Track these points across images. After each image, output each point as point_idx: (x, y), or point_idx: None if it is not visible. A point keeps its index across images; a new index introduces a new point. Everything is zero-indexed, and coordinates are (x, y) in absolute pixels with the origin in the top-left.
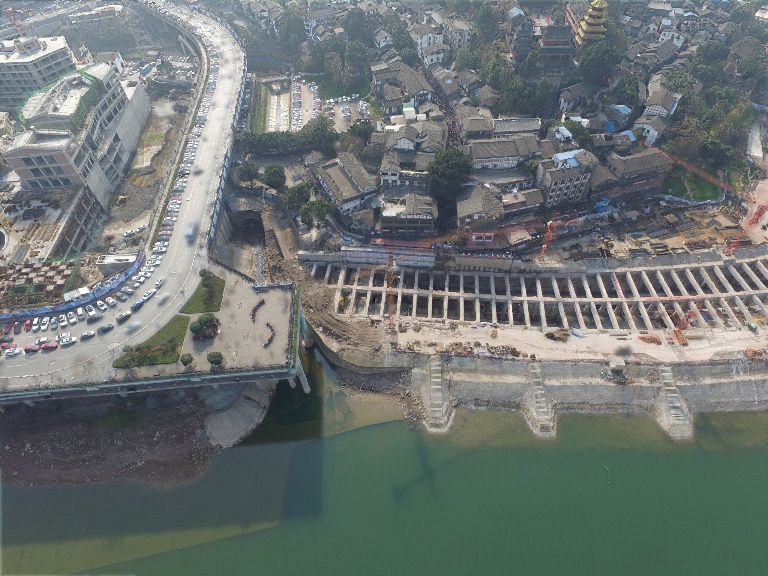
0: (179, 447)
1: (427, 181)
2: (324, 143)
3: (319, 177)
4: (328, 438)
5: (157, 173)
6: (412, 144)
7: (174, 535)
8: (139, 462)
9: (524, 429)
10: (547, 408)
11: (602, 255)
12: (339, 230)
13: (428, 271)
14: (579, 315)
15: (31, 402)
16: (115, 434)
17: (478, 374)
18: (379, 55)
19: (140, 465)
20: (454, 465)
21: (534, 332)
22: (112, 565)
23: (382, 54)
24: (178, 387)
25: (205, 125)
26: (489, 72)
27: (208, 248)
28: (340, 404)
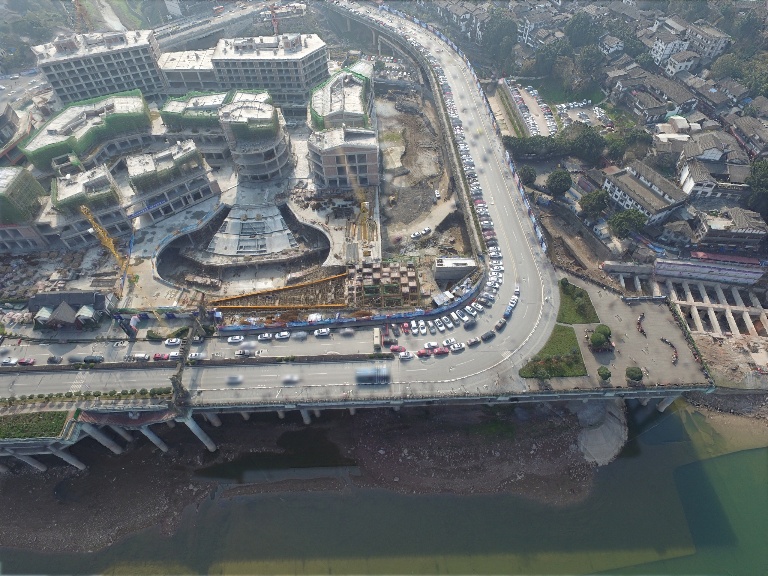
0: (556, 462)
1: (744, 194)
2: (596, 150)
3: (604, 185)
4: (706, 461)
5: (412, 174)
6: (720, 155)
7: (590, 556)
8: (519, 475)
9: None
10: None
11: None
12: (646, 241)
13: (747, 288)
14: None
15: None
16: (493, 445)
17: None
18: (609, 61)
19: (521, 478)
20: None
21: None
22: None
23: (612, 60)
24: None
25: (463, 127)
26: (763, 82)
27: None
28: (701, 425)
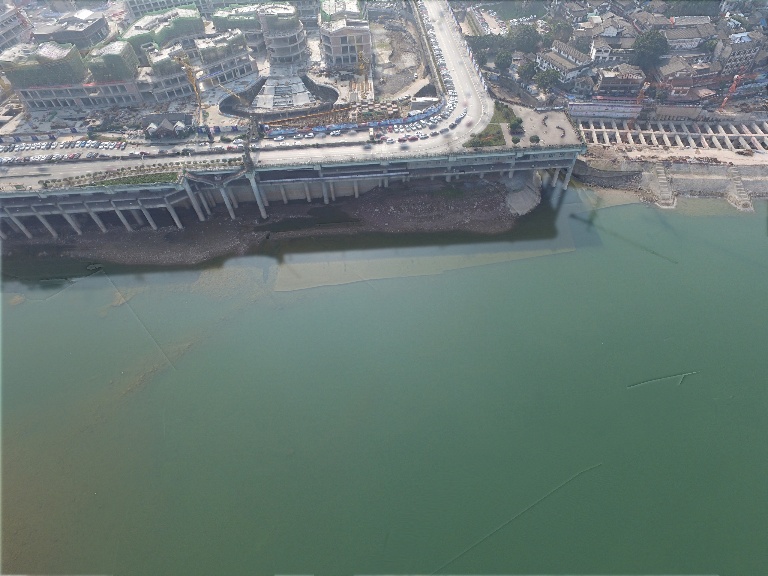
0: (491, 212)
1: (631, 56)
2: (532, 40)
3: (537, 61)
4: (590, 211)
5: (398, 67)
6: (616, 31)
7: (508, 253)
8: (466, 220)
9: (729, 207)
10: (745, 194)
11: (767, 109)
12: (563, 93)
13: (633, 121)
14: (757, 143)
15: (387, 183)
16: (449, 202)
17: (691, 175)
18: None
19: (468, 222)
20: (686, 224)
21: (727, 151)
22: (474, 266)
23: None
24: (492, 171)
25: (435, 30)
26: None
27: (488, 93)
28: (591, 195)
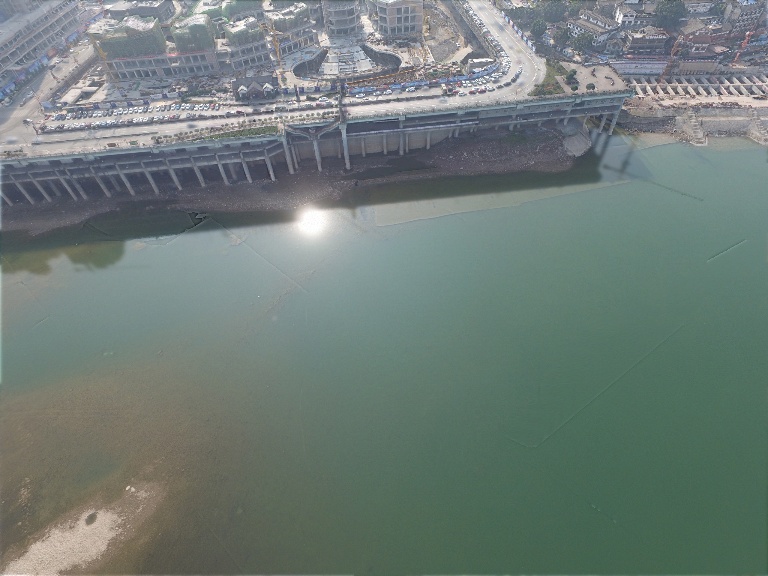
0: (552, 155)
1: (654, 20)
2: (560, 11)
3: None
4: (636, 151)
5: (438, 39)
6: None
7: (574, 187)
8: (531, 162)
9: (753, 143)
10: (765, 131)
11: None
12: (596, 54)
13: (659, 77)
14: None
15: None
16: (515, 147)
17: (718, 117)
18: None
19: (532, 163)
20: (719, 157)
21: (745, 97)
22: (547, 198)
23: None
24: (551, 118)
25: (470, 4)
26: None
27: None
28: (633, 139)
